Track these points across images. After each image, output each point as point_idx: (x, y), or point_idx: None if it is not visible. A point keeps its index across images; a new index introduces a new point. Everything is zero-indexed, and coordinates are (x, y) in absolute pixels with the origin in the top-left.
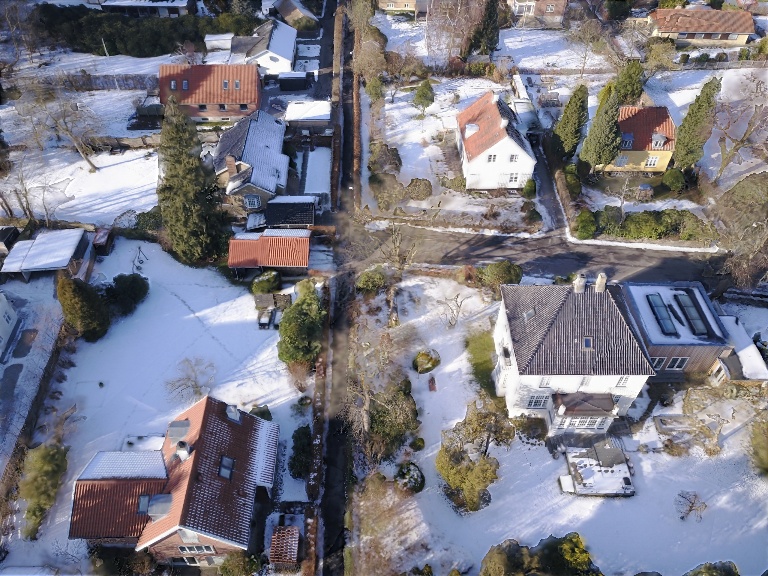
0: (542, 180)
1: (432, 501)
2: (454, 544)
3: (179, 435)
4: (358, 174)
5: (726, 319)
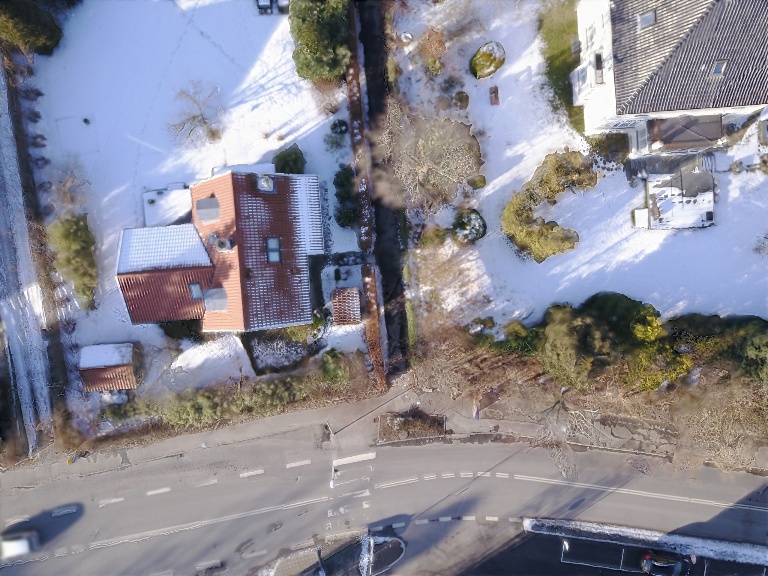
0: None
1: (493, 247)
2: (516, 292)
3: (211, 218)
4: None
5: None
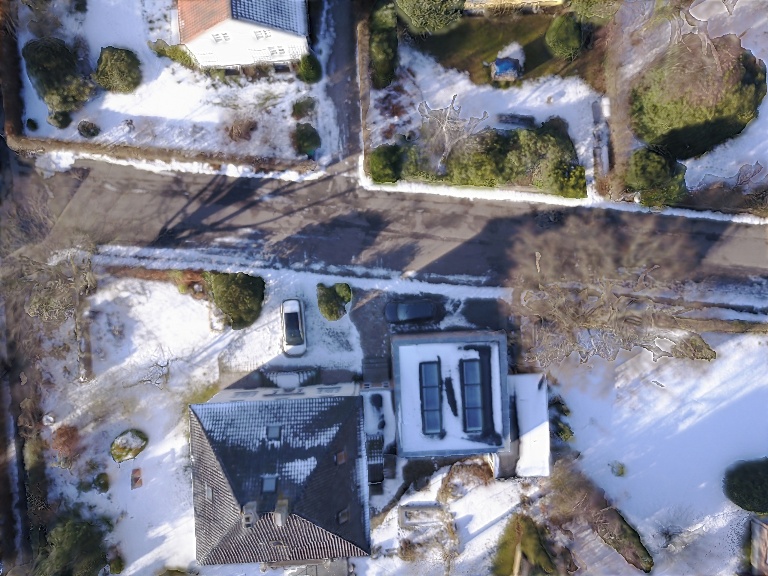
0: (338, 29)
1: None
2: None
3: None
4: (2, 39)
5: (528, 379)
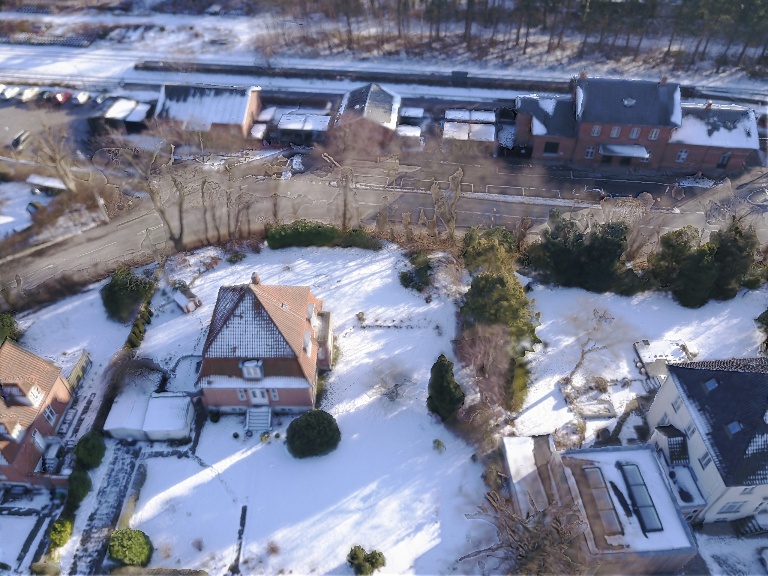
0: None
1: None
2: (763, 305)
3: None
4: None
5: None
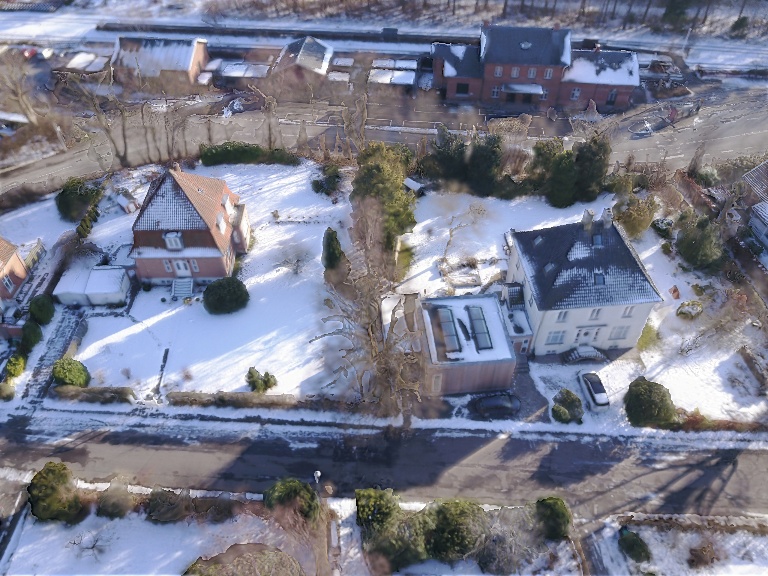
0: None
1: None
2: None
3: None
4: None
5: None
